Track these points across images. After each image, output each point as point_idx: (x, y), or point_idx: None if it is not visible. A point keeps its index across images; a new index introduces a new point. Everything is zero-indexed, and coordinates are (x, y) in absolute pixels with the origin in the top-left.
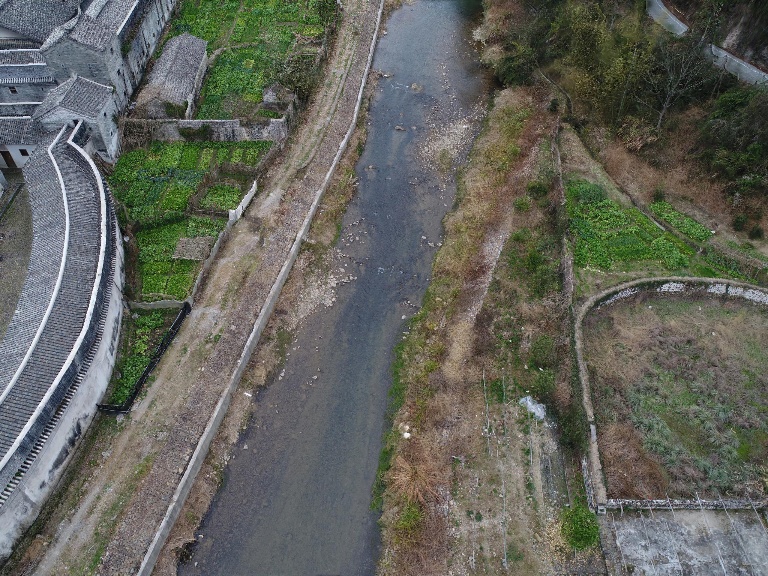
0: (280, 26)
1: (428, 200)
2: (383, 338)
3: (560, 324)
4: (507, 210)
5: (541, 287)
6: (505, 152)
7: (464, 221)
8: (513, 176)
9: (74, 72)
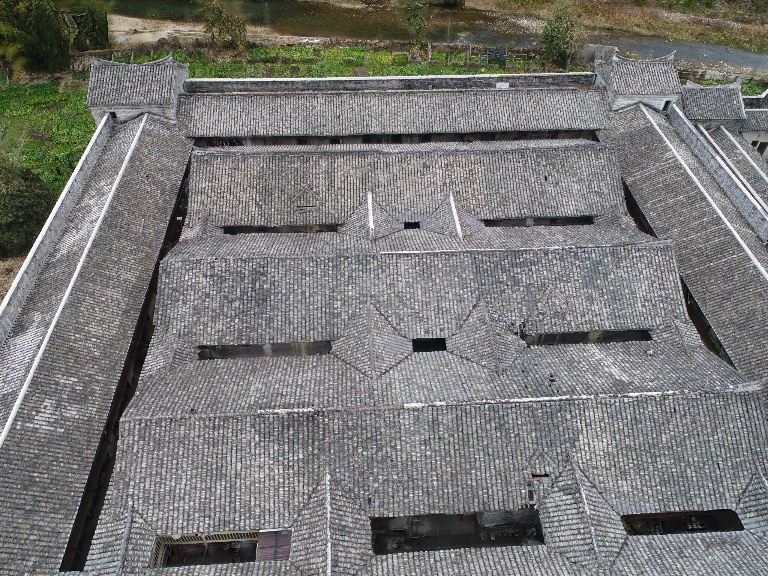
0: (373, 73)
1: (625, 39)
2: (760, 57)
3: (732, 4)
4: (635, 11)
5: (715, 1)
6: (567, 7)
7: (645, 28)
8: (600, 5)
9: (689, 82)
